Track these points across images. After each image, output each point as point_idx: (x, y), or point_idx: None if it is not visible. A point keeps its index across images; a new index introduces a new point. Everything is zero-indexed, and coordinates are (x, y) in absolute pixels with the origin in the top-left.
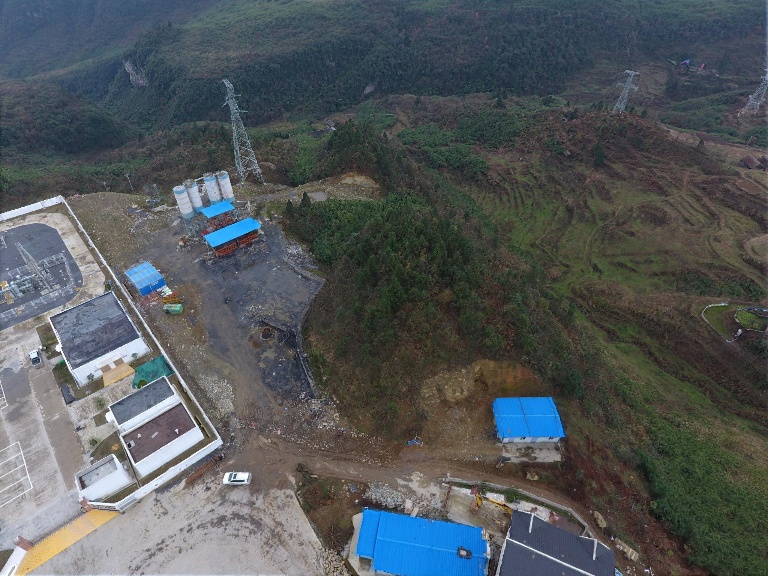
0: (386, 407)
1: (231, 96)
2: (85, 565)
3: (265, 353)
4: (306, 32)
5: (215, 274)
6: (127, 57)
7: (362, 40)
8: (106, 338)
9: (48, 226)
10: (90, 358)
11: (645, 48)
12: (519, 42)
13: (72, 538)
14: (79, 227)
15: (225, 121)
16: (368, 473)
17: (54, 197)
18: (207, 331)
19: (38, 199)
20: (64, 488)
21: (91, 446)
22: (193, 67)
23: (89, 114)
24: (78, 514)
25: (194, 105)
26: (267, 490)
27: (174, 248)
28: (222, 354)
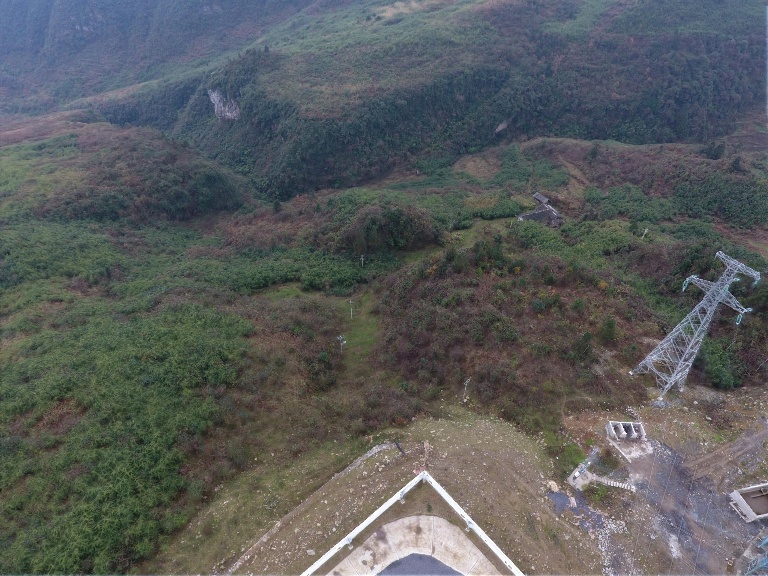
0: None
1: None
2: None
3: None
4: (433, 60)
5: None
6: (215, 87)
7: (497, 70)
8: None
9: (445, 565)
10: None
11: None
12: (687, 74)
13: None
14: None
15: (344, 169)
16: None
17: (417, 476)
18: None
19: (283, 394)
20: None
21: None
22: (304, 103)
23: (204, 171)
24: None
25: (312, 151)
26: None
27: None
28: None
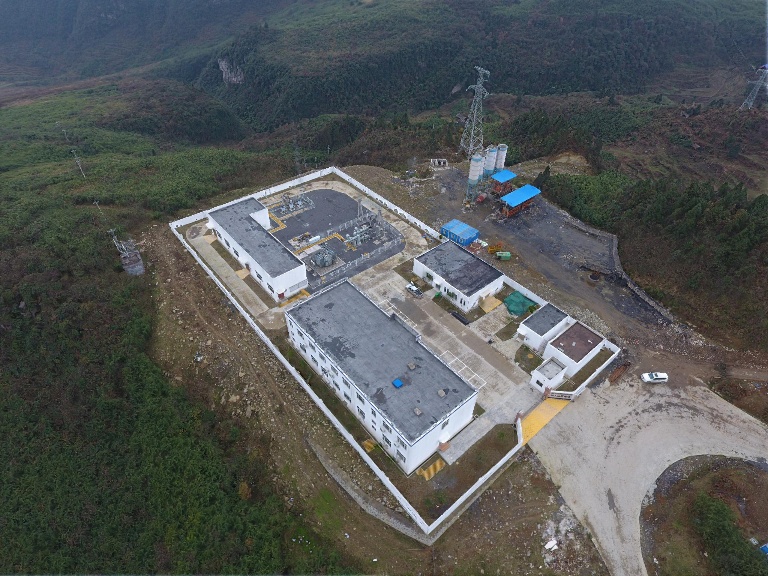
0: (764, 324)
1: (481, 81)
2: (568, 436)
3: (603, 290)
4: (400, 34)
5: (513, 231)
6: (224, 56)
7: (452, 42)
8: (474, 274)
9: (336, 191)
10: (474, 289)
11: (722, 53)
12: (604, 45)
13: (546, 417)
14: (368, 192)
15: None
16: (763, 375)
17: None
18: (542, 273)
19: (268, 174)
20: (513, 383)
21: (510, 355)
22: (296, 65)
23: (217, 107)
24: (539, 401)
25: (300, 101)
26: (683, 387)
27: (459, 210)
28: (569, 290)
